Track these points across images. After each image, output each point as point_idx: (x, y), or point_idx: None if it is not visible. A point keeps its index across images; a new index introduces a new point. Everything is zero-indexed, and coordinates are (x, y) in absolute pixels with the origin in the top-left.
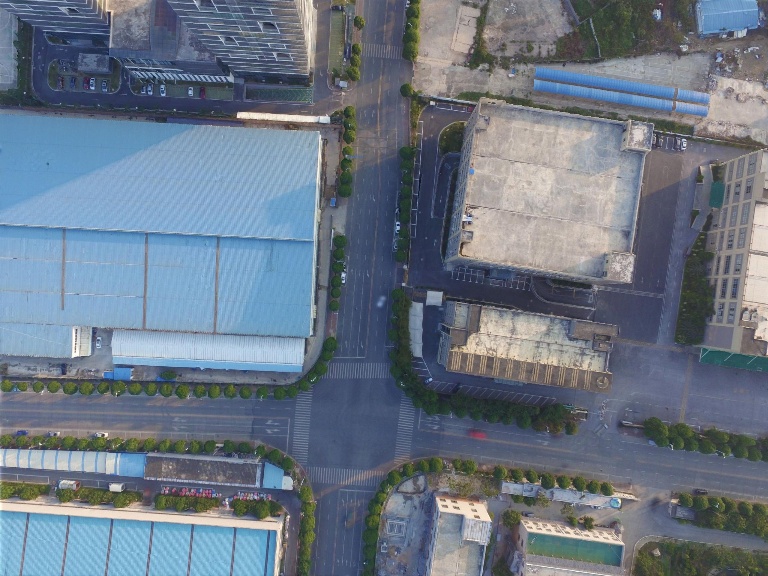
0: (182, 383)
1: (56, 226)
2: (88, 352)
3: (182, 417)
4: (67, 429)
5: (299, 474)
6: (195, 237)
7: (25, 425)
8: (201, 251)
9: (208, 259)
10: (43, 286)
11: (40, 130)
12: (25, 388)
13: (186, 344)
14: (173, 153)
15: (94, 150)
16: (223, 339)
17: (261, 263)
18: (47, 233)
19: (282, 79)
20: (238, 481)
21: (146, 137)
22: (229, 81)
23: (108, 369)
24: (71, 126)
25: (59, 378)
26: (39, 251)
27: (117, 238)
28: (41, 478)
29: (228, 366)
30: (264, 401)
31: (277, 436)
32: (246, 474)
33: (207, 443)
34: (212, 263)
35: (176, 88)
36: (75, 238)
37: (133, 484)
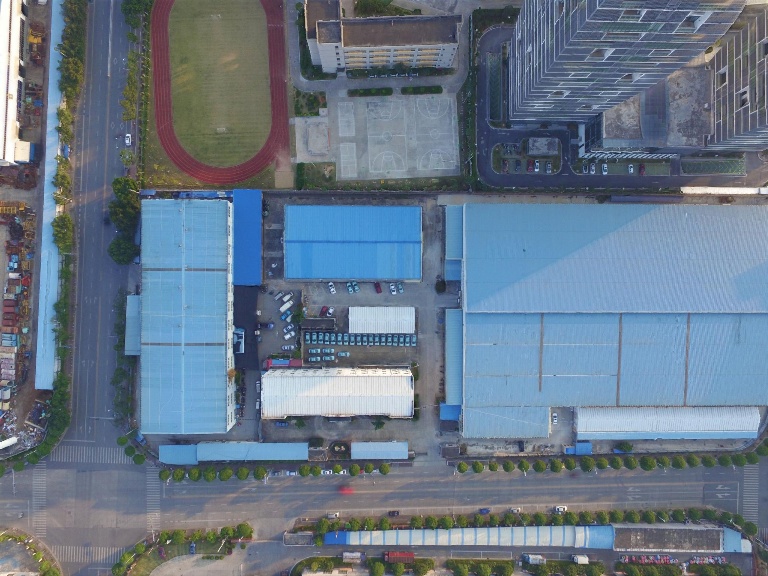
0: (638, 454)
1: (539, 311)
2: (550, 429)
3: (636, 487)
4: (526, 504)
5: (751, 536)
6: (667, 314)
7: (486, 503)
8: (672, 328)
9: (679, 335)
10: (521, 369)
11: (512, 217)
12: (497, 468)
13: (649, 417)
14: (641, 233)
15: (566, 234)
16: (683, 410)
17: (729, 336)
18: (526, 318)
19: (720, 153)
20: (704, 547)
21: (614, 219)
22: (669, 157)
23: (563, 444)
24: (542, 212)
25: (521, 456)
26: (518, 336)
27: (592, 319)
28: (504, 554)
29: (687, 436)
30: (714, 467)
31: (728, 500)
32: (711, 540)
33: (677, 513)
34: (683, 339)
35: (615, 166)
36: (553, 321)
37: (593, 554)
